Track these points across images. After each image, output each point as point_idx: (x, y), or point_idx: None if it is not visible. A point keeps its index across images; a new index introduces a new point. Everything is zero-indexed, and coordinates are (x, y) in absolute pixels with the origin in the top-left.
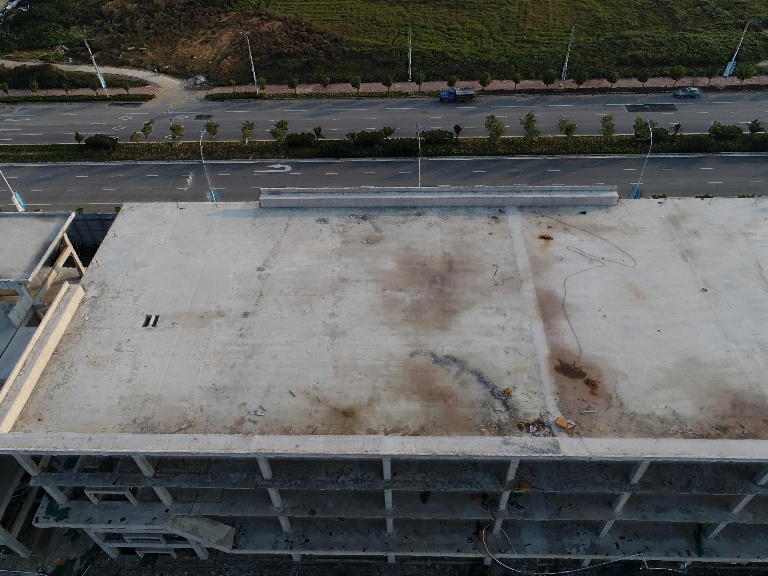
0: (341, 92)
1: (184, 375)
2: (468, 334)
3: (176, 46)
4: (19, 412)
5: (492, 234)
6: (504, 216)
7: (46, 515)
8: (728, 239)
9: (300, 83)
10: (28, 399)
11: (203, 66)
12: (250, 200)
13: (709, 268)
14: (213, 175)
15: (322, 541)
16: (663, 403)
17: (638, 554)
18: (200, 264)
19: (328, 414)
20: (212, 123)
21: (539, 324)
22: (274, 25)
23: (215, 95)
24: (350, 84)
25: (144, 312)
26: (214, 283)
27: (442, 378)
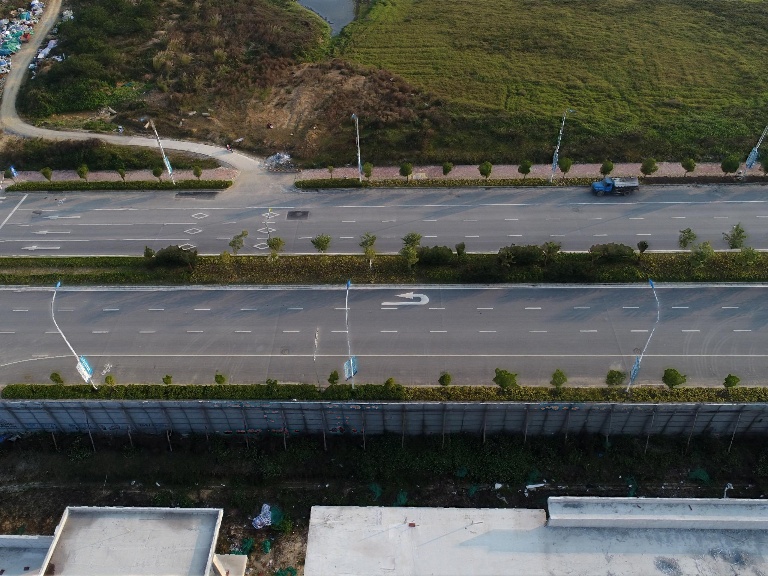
0: (464, 179)
1: None
2: None
3: (246, 110)
4: None
5: None
6: None
7: None
8: None
9: None
10: None
11: (284, 139)
12: (386, 352)
13: None
14: (328, 309)
15: None
16: None
17: None
18: None
19: None
20: (323, 237)
21: None
22: (358, 81)
23: (307, 183)
24: (472, 167)
25: None
26: None
27: None
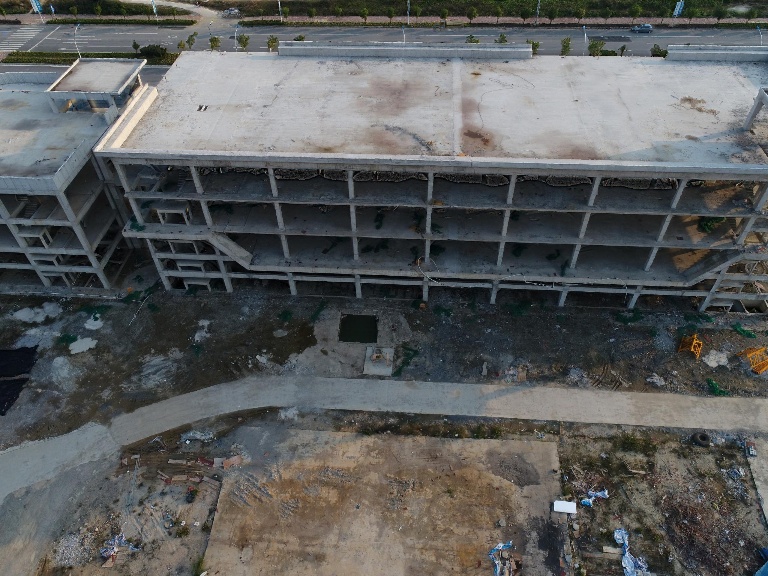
0: (351, 22)
1: (224, 132)
2: (411, 118)
3: None
4: (121, 144)
5: (439, 71)
6: (450, 63)
7: (131, 228)
8: (603, 77)
9: (317, 15)
10: (126, 140)
11: (237, 1)
12: None
13: (584, 90)
14: None
15: (310, 263)
16: (528, 149)
17: (521, 274)
18: (235, 82)
19: (315, 149)
20: (243, 36)
21: (459, 114)
22: None
23: (246, 22)
24: (359, 17)
25: (198, 104)
26: (245, 91)
27: (390, 136)
